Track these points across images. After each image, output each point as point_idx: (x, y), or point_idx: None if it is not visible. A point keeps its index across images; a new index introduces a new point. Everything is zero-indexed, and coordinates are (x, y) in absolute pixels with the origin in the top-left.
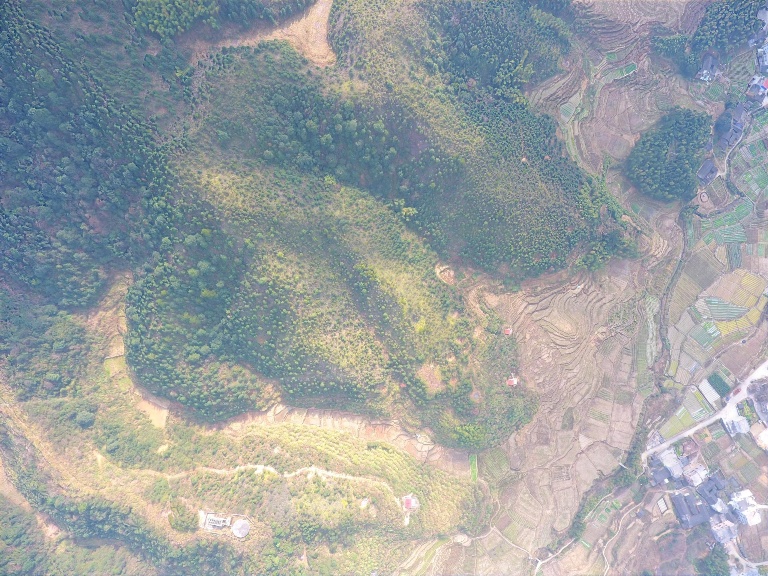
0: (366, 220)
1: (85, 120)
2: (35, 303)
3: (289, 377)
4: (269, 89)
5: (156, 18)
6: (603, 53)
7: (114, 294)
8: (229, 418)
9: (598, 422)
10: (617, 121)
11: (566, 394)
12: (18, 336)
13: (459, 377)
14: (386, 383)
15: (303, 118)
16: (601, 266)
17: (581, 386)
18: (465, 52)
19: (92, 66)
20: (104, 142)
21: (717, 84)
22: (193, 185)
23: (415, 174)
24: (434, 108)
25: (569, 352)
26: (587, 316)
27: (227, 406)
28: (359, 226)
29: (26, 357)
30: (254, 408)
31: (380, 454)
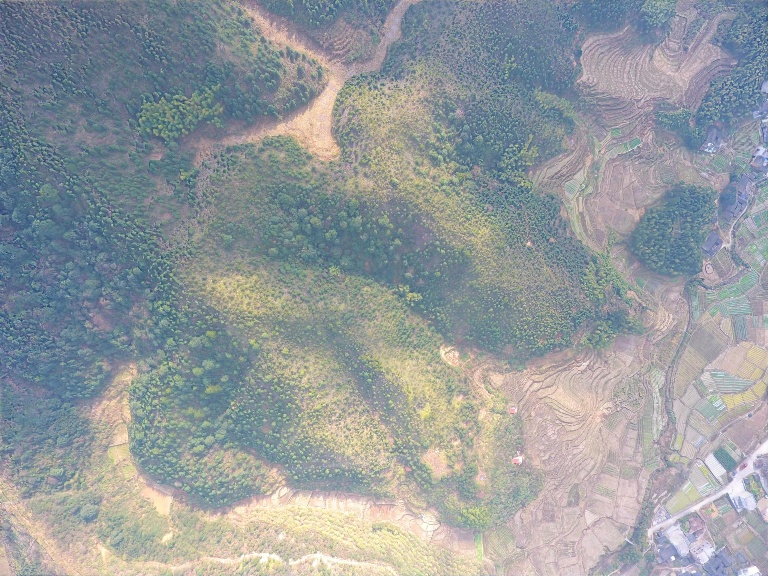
0: (371, 310)
1: (89, 229)
2: (39, 397)
3: (294, 464)
4: (274, 188)
5: (160, 123)
6: (607, 129)
7: (118, 384)
8: (233, 502)
9: (604, 498)
10: (621, 195)
11: (572, 470)
12: (22, 435)
13: (464, 461)
14: (391, 467)
15: (308, 214)
16: (606, 345)
17: (587, 462)
18: (470, 141)
19: (96, 178)
20: (108, 248)
21: (721, 155)
22: (198, 292)
23: (420, 263)
24: (439, 202)
25: (574, 429)
26: (592, 392)
27: (232, 492)
28: (364, 317)
29: (30, 455)
30: (259, 493)
31: (385, 536)
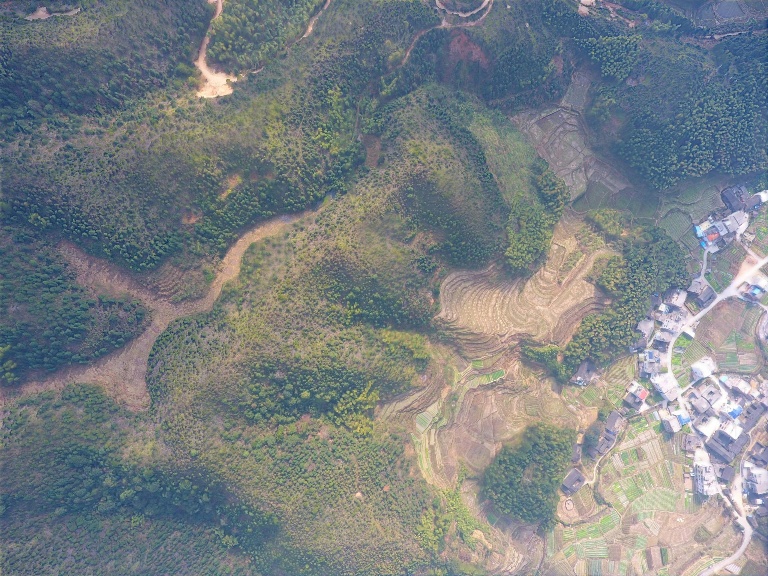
0: (175, 561)
1: None
2: None
3: None
4: (63, 451)
5: None
6: (468, 360)
7: None
8: None
9: None
10: (480, 426)
11: None
12: None
13: None
14: None
15: (103, 473)
16: None
17: None
18: (296, 395)
19: None
20: None
21: (593, 388)
22: None
23: (232, 515)
24: (246, 469)
25: None
26: None
27: None
28: (163, 573)
29: None
30: None
31: None
